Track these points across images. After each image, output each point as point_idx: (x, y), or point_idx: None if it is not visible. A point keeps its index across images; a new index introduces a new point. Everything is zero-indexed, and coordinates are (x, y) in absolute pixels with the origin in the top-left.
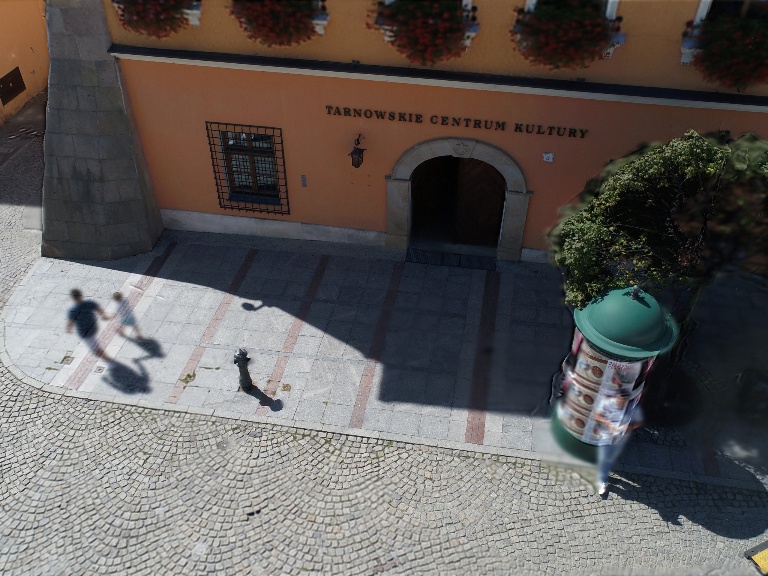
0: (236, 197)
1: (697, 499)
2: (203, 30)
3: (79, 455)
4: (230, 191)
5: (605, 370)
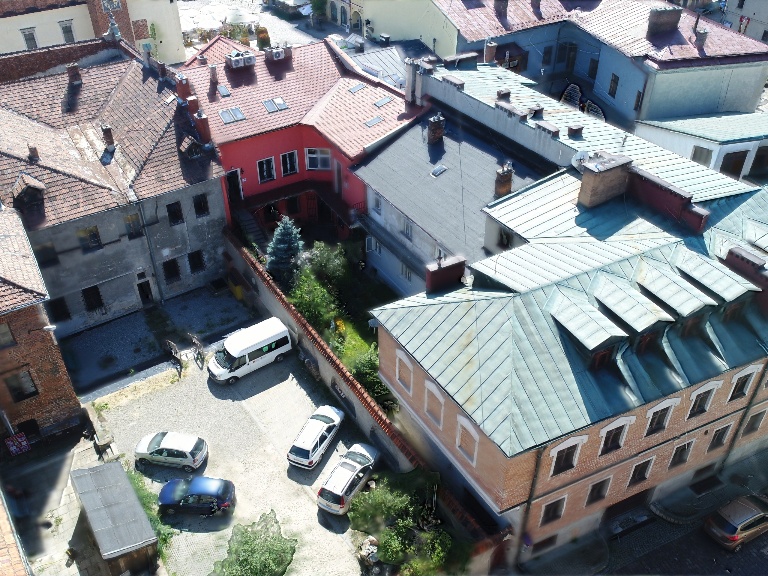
0: None
1: (264, 10)
2: None
3: (239, 1)
4: None
5: None
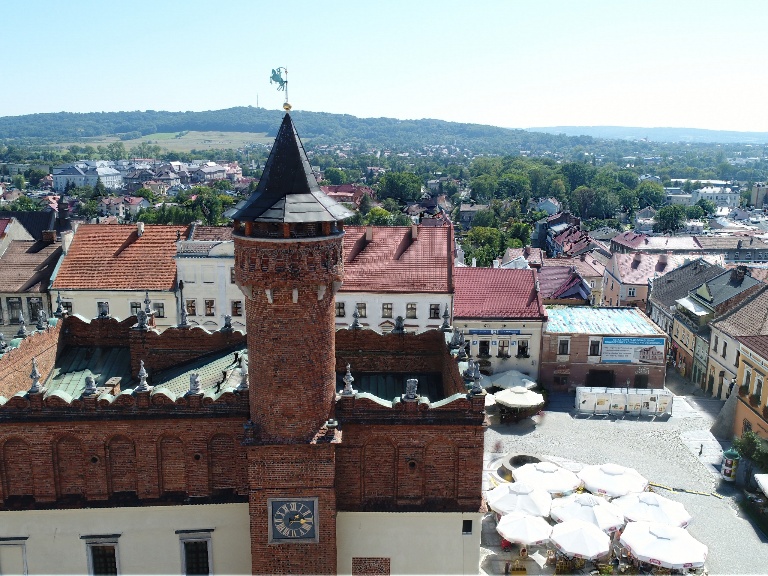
0: None
1: None
2: None
3: None
4: None
5: None
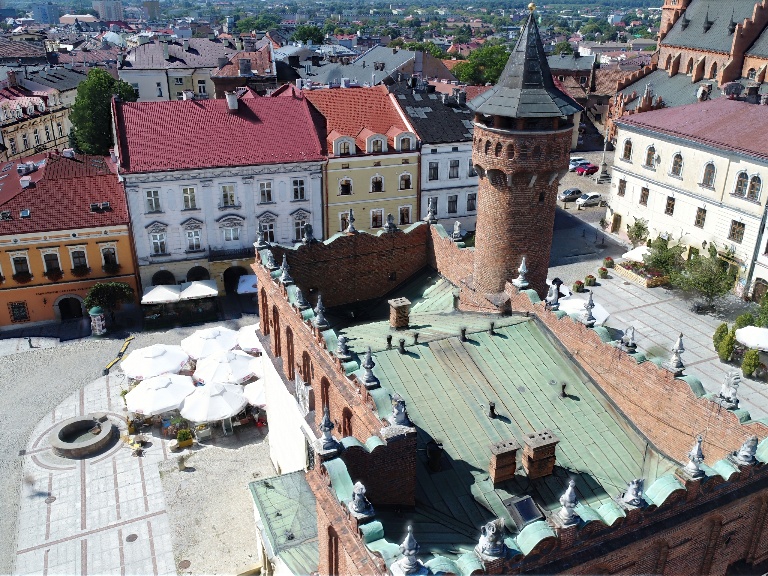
0: (16, 319)
1: (118, 337)
2: (6, 284)
3: None
4: (14, 318)
5: (96, 319)
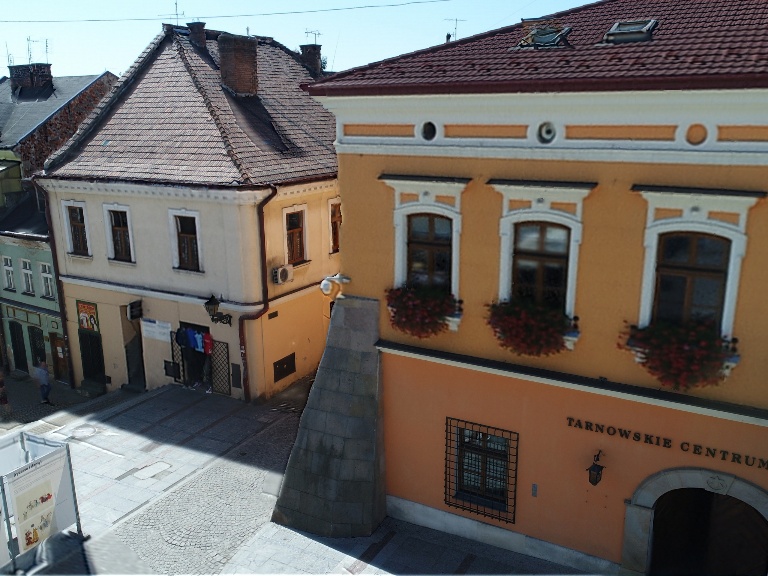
0: (462, 496)
1: None
2: (460, 335)
3: None
4: (457, 488)
5: None
